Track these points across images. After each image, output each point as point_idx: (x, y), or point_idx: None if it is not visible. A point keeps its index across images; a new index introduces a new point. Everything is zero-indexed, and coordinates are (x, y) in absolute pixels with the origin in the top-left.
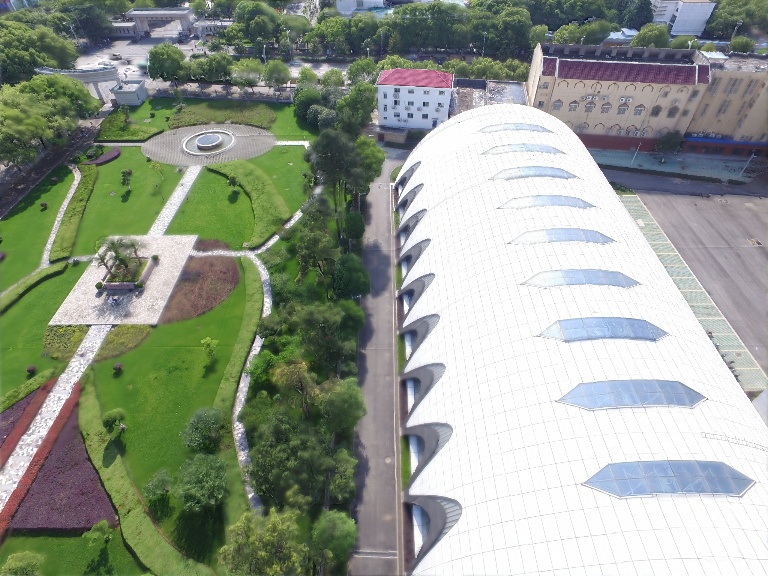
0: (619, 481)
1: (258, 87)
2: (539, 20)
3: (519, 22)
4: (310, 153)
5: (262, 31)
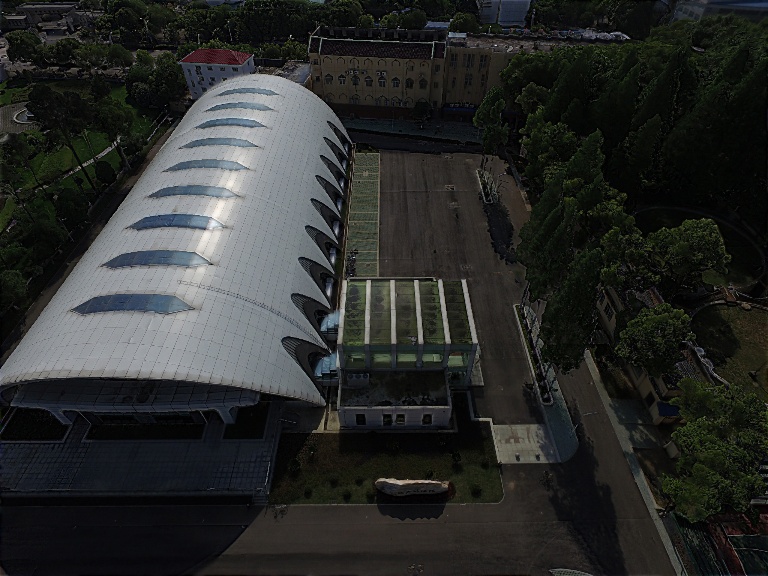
0: (91, 306)
1: (110, 70)
2: (381, 12)
3: (345, 12)
4: (31, 104)
5: (127, 22)
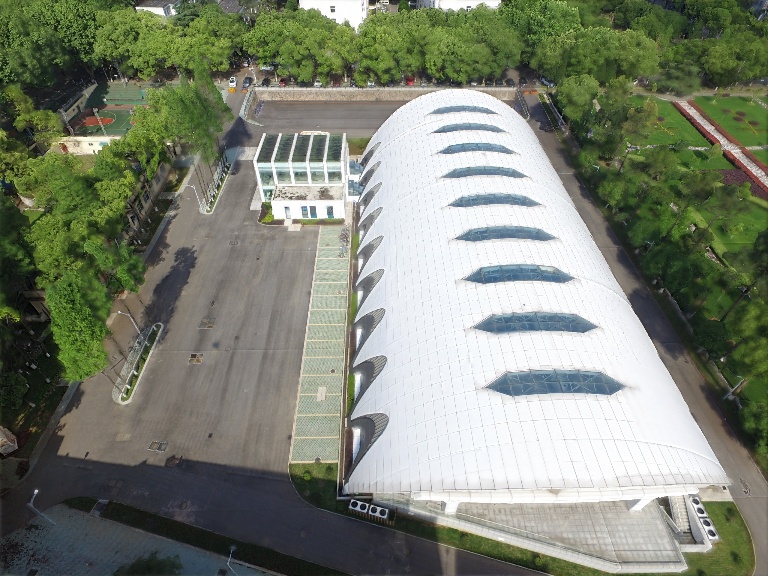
0: None
1: None
2: None
3: None
4: None
5: None
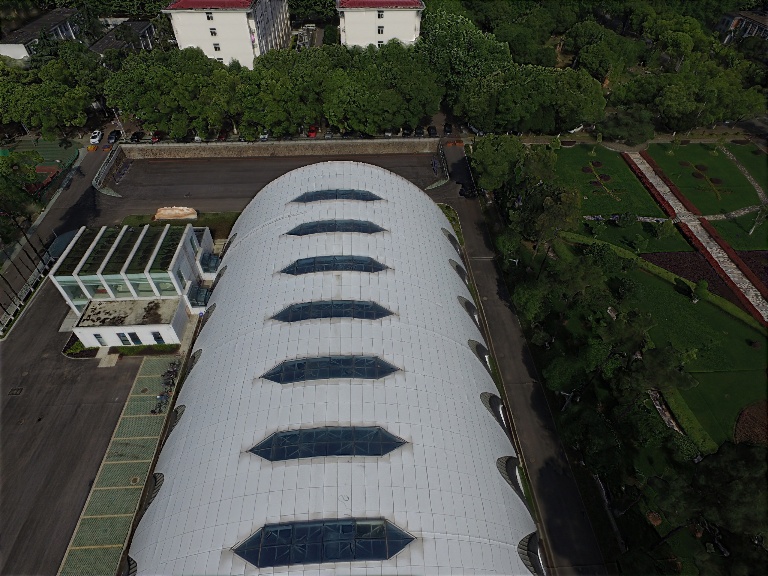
0: None
1: None
2: None
3: None
4: None
5: None
